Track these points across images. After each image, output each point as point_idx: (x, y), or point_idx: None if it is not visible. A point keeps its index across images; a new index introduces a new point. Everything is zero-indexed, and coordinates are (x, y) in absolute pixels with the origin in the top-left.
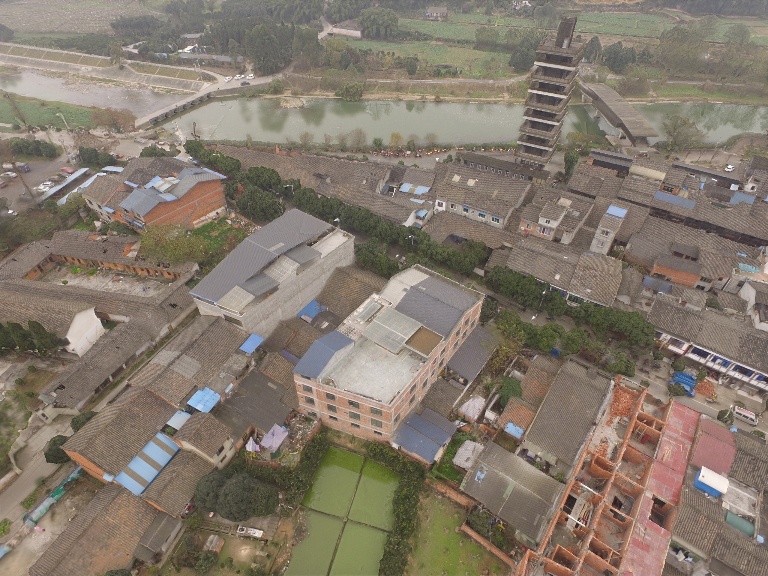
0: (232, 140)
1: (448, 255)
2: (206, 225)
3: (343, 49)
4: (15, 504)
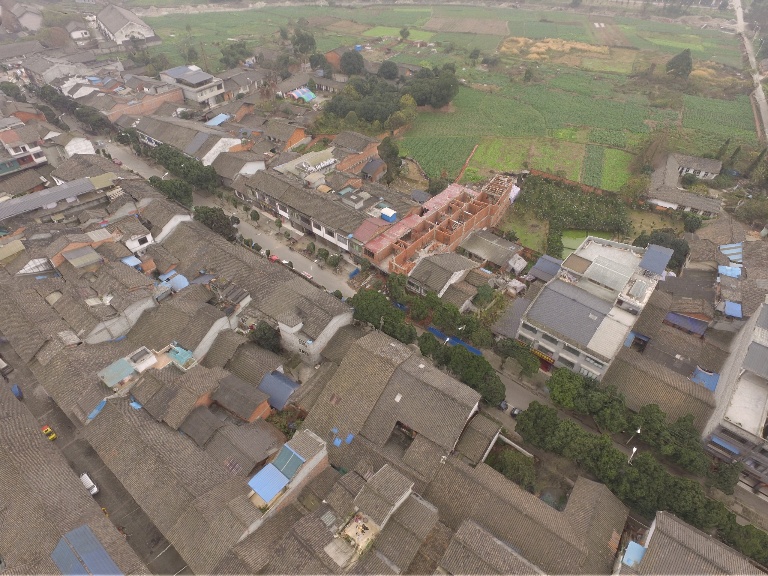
0: None
1: None
2: None
3: None
4: None
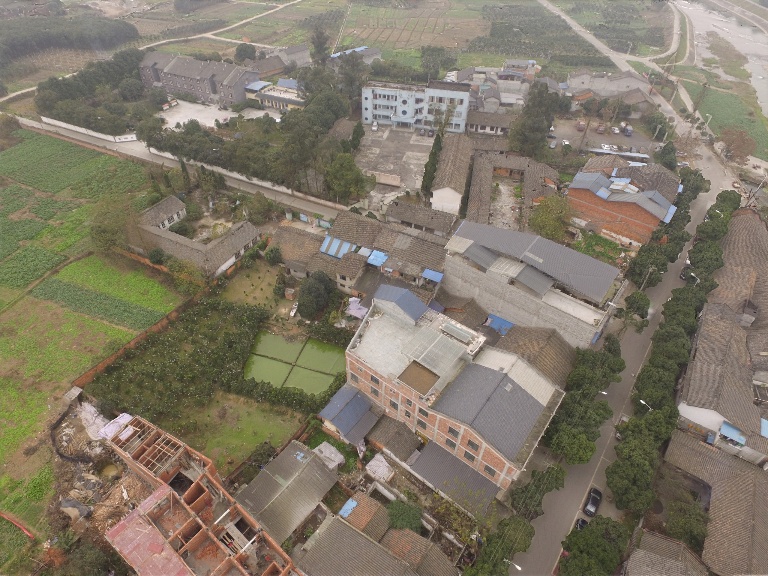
0: None
1: (630, 458)
2: (609, 241)
3: None
4: (331, 216)
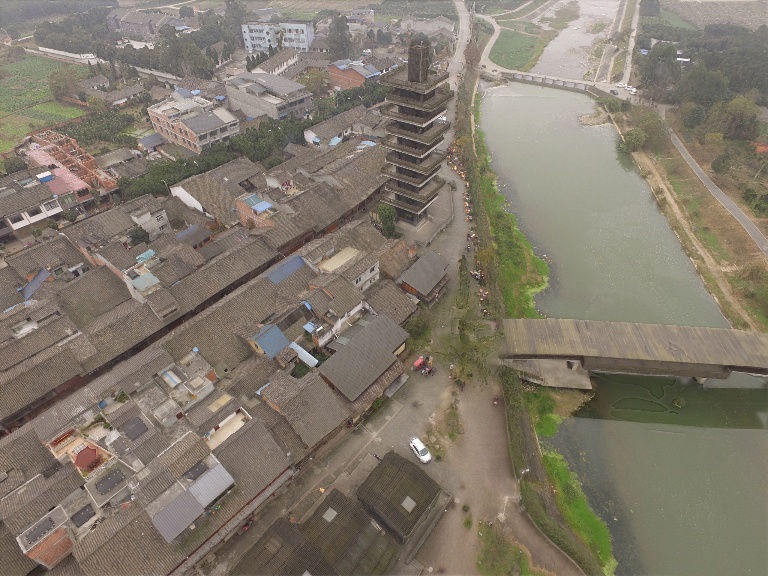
0: (463, 91)
1: None
2: None
3: (733, 112)
4: None
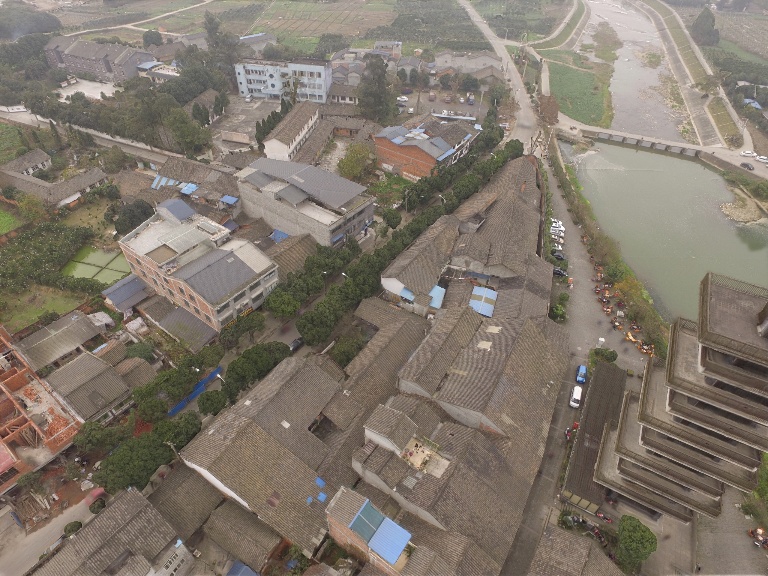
0: (562, 171)
1: None
2: (408, 181)
3: None
4: None
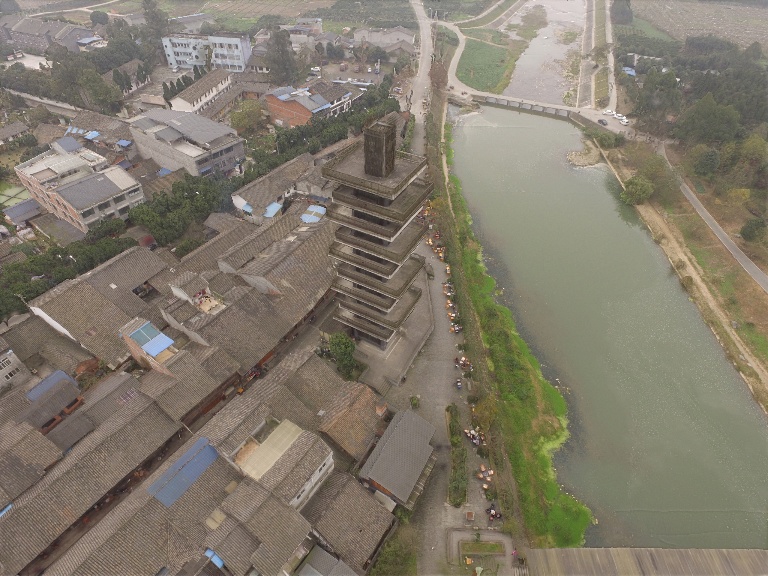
0: (431, 124)
1: None
2: None
3: (749, 156)
4: None
